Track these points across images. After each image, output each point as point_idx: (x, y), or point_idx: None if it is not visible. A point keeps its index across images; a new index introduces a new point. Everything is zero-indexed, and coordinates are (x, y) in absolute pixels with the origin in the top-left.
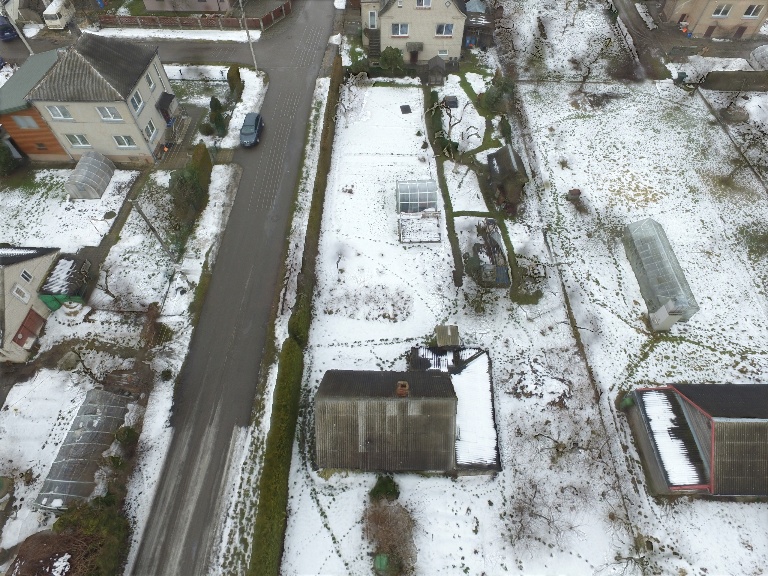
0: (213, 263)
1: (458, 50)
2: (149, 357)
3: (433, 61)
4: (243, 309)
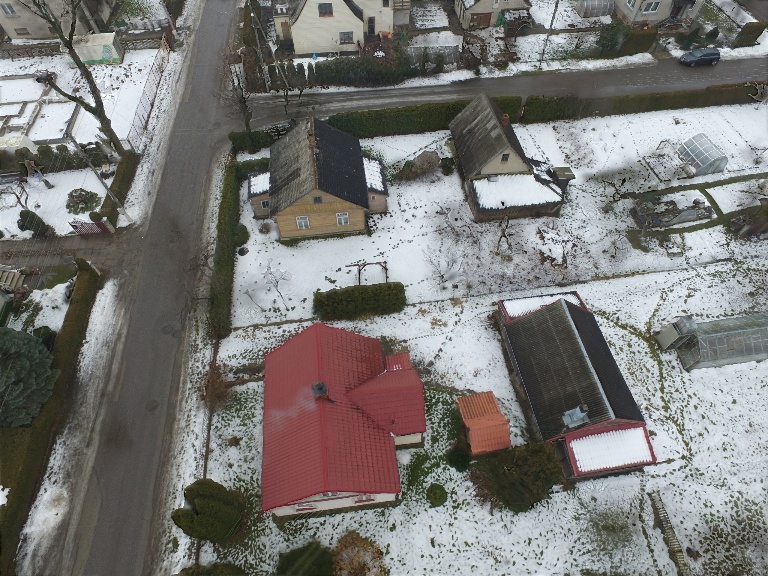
0: (562, 72)
1: None
2: (486, 66)
3: None
4: (535, 91)
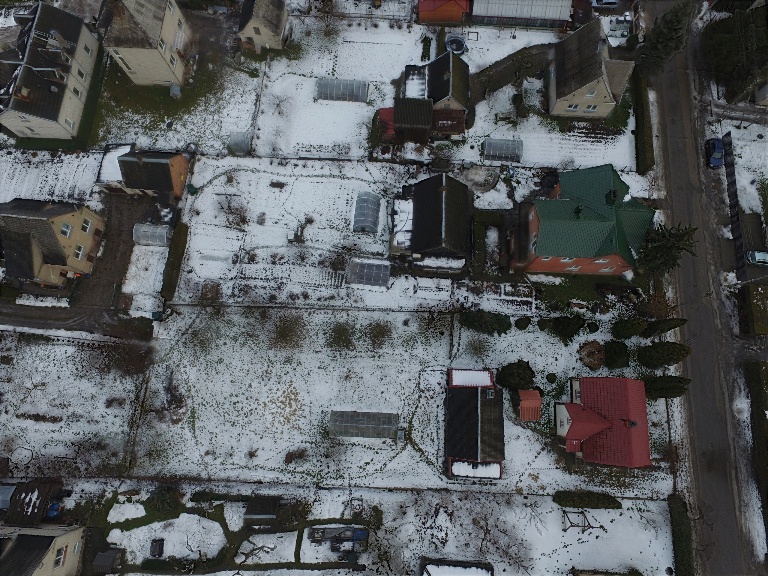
0: None
1: (77, 532)
2: None
3: (100, 568)
4: None
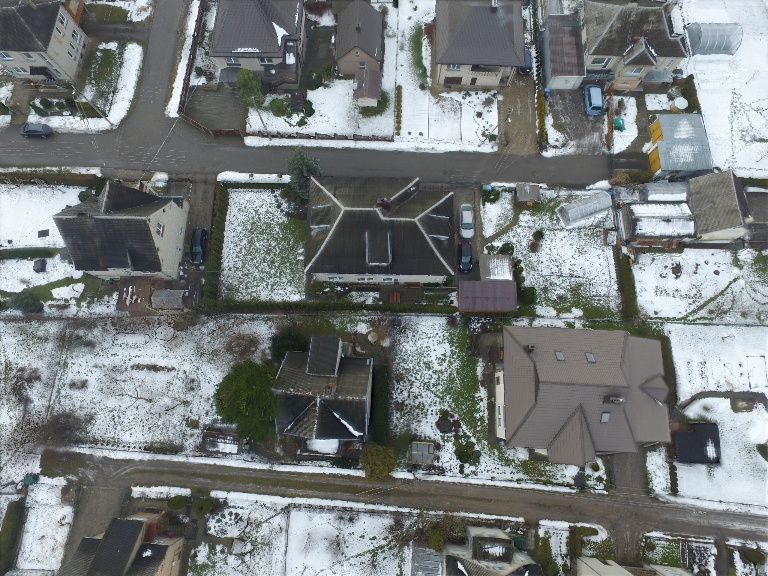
0: None
1: None
2: None
3: None
4: None
